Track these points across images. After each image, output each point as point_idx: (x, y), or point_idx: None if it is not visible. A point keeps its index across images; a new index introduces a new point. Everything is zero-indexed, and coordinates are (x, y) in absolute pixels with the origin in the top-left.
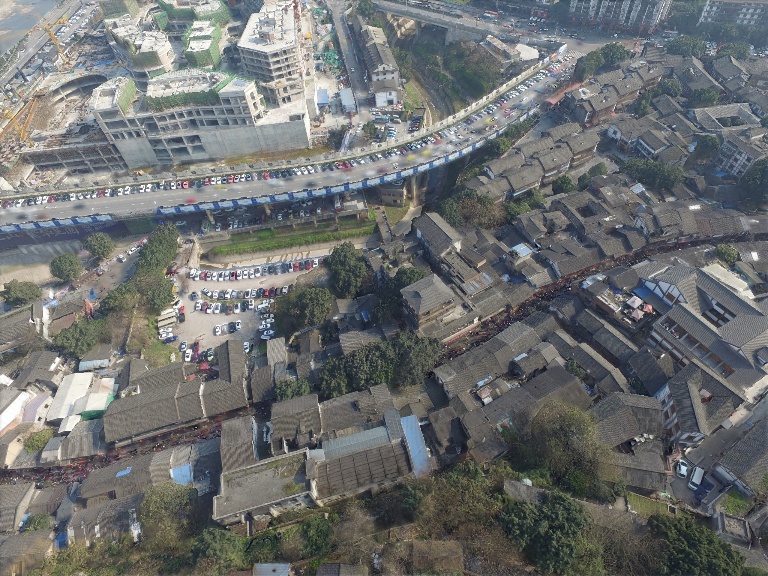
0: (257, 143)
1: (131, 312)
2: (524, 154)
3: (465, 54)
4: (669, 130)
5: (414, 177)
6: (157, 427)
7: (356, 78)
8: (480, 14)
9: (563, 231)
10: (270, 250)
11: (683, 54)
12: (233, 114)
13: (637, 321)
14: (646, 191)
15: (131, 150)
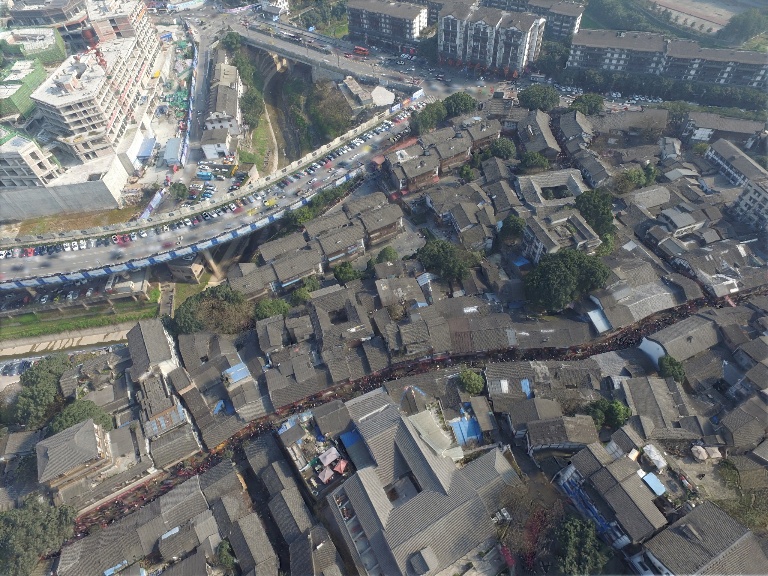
0: (56, 204)
1: None
2: (308, 234)
3: (323, 96)
4: (488, 201)
5: (205, 251)
6: None
7: (198, 123)
8: (351, 50)
9: (306, 342)
10: (35, 336)
11: (533, 106)
12: (17, 175)
13: (325, 483)
14: (431, 284)
15: None
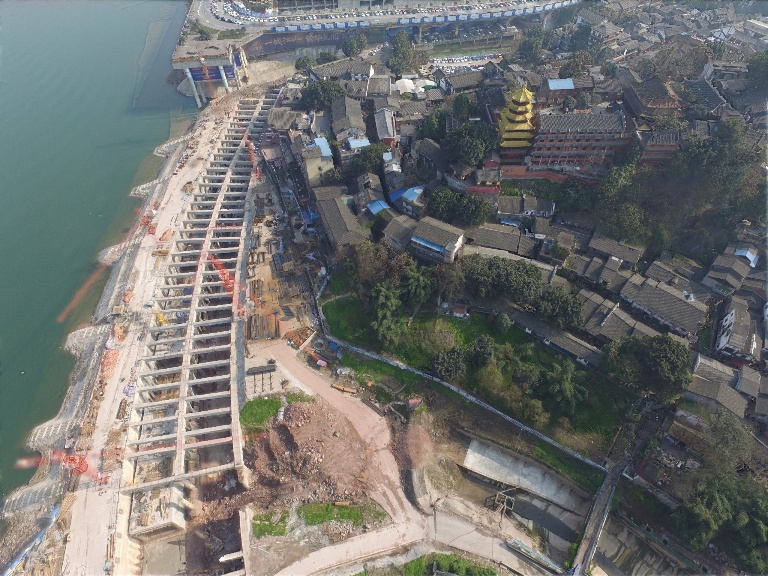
0: (429, 1)
1: (406, 67)
2: None
3: None
4: None
5: None
6: (477, 84)
7: None
8: None
9: None
10: None
11: None
12: None
13: None
14: (700, 12)
15: (346, 0)
